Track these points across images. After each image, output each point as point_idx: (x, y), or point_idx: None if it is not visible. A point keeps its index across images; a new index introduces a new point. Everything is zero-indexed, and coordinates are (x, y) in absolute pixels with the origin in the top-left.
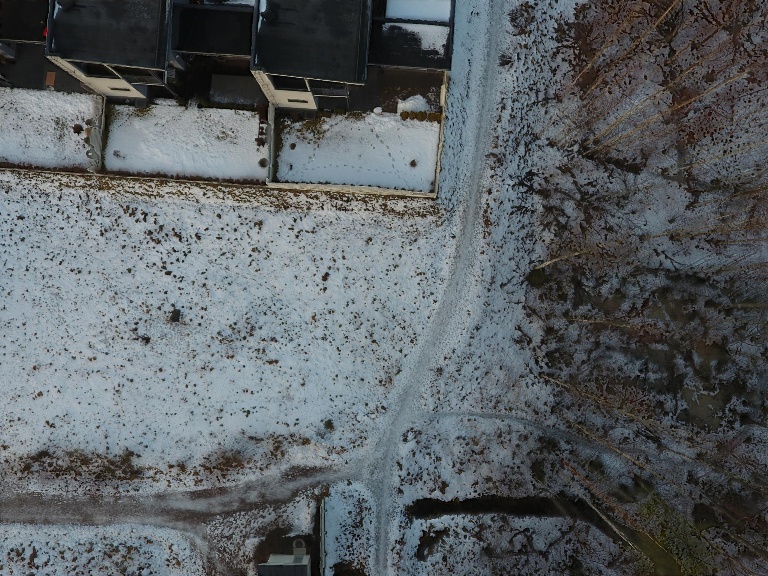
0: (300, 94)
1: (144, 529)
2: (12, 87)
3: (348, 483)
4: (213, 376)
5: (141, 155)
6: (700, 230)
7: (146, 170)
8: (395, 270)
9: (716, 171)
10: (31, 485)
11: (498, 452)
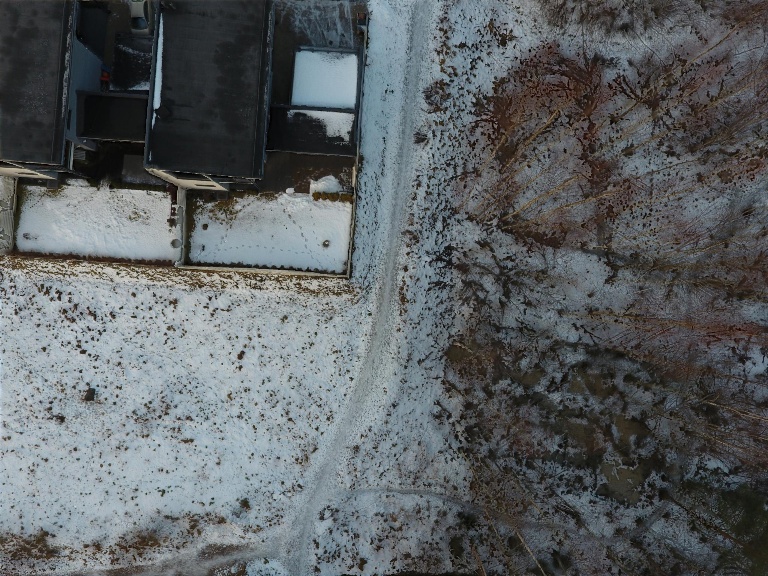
0: (204, 182)
1: None
2: None
3: (265, 561)
4: (128, 455)
5: (53, 236)
6: (619, 304)
7: (58, 251)
8: (311, 348)
9: (635, 245)
10: None
11: (417, 528)
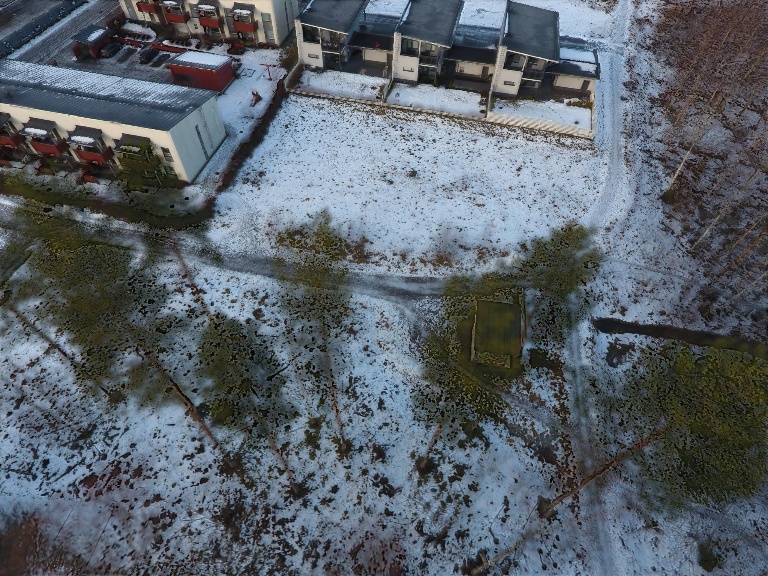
0: (515, 75)
1: (362, 296)
2: (341, 71)
3: (540, 290)
4: (436, 206)
5: (409, 101)
6: None
7: None
8: (567, 173)
9: None
10: (279, 253)
11: (666, 294)
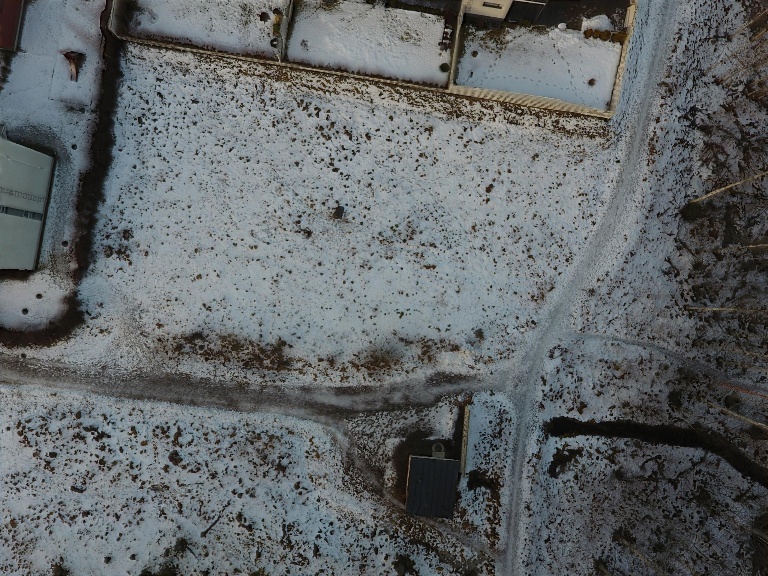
0: None
1: (287, 420)
2: None
3: (491, 393)
4: (371, 275)
5: (325, 49)
6: None
7: None
8: (558, 188)
9: None
10: (180, 366)
11: (637, 378)
